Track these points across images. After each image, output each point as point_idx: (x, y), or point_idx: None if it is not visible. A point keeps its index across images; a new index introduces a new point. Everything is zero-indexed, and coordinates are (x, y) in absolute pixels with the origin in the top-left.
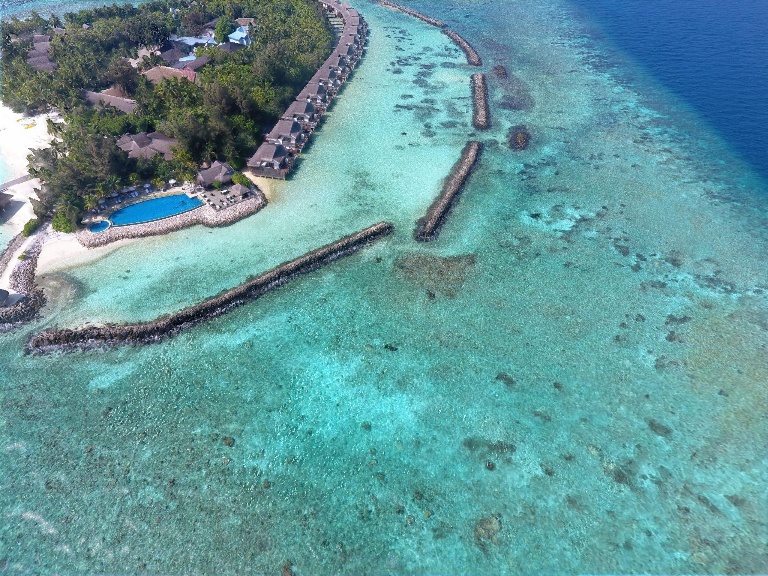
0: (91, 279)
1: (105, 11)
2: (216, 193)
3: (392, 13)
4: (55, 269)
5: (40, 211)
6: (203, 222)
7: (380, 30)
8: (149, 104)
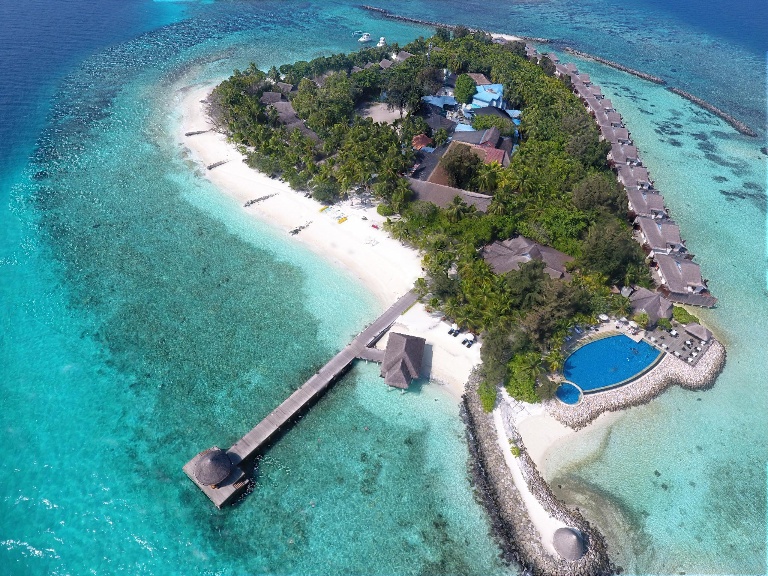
0: (622, 489)
1: (324, 63)
2: (663, 334)
3: (591, 65)
4: (561, 469)
5: (504, 375)
6: (678, 382)
7: (601, 86)
8: (508, 201)
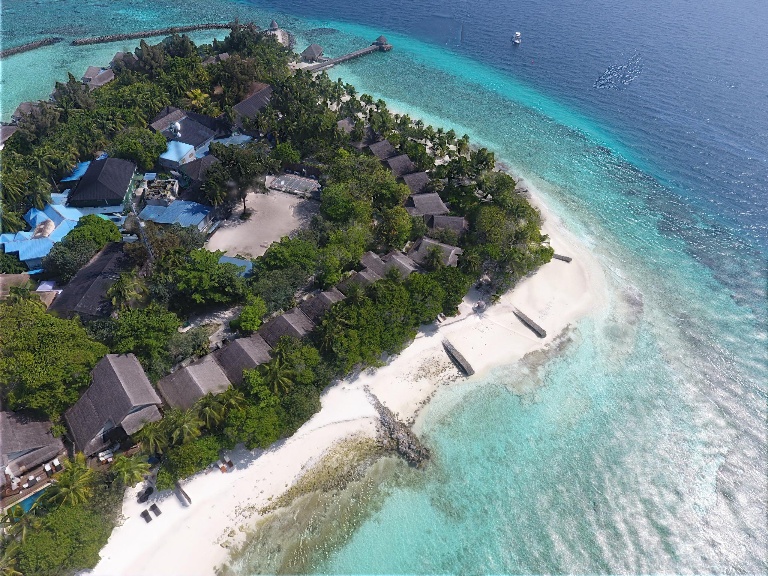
0: None
1: None
2: None
3: None
4: None
5: None
6: None
7: None
8: None
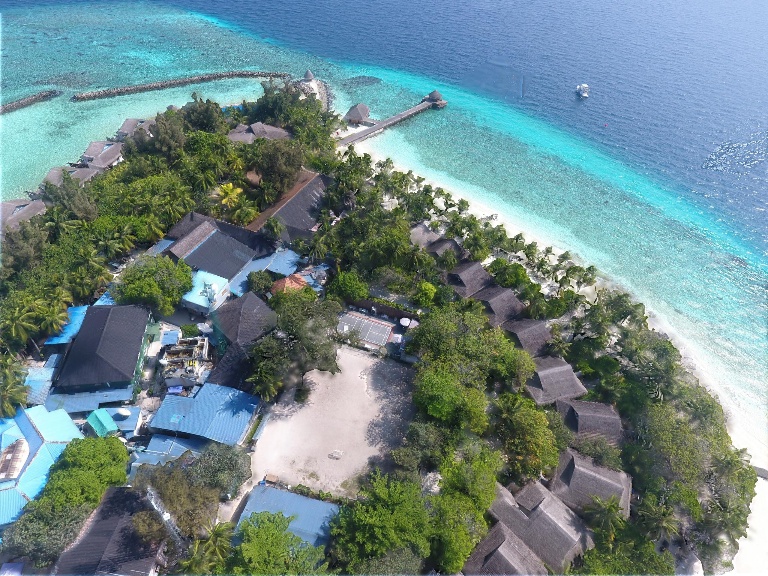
0: None
1: None
2: None
3: None
4: None
5: None
6: None
7: None
8: (249, 145)
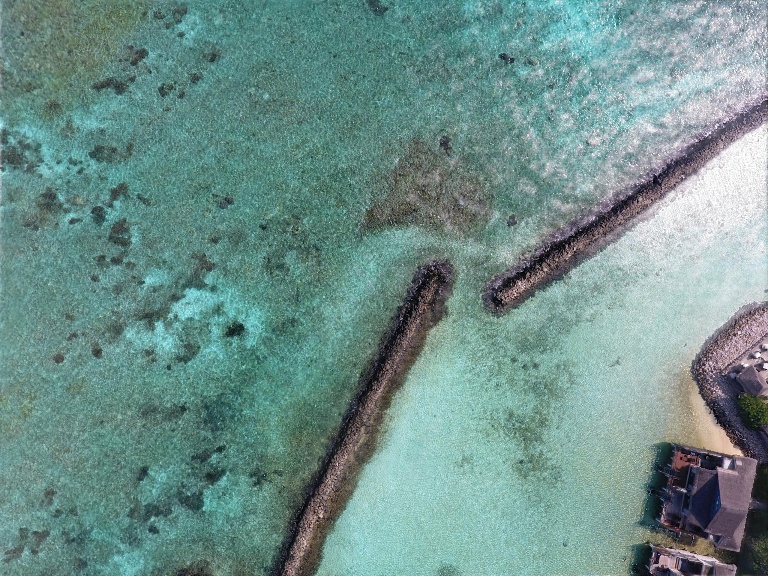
0: None
1: None
2: None
3: None
4: None
5: None
6: None
7: None
8: None
